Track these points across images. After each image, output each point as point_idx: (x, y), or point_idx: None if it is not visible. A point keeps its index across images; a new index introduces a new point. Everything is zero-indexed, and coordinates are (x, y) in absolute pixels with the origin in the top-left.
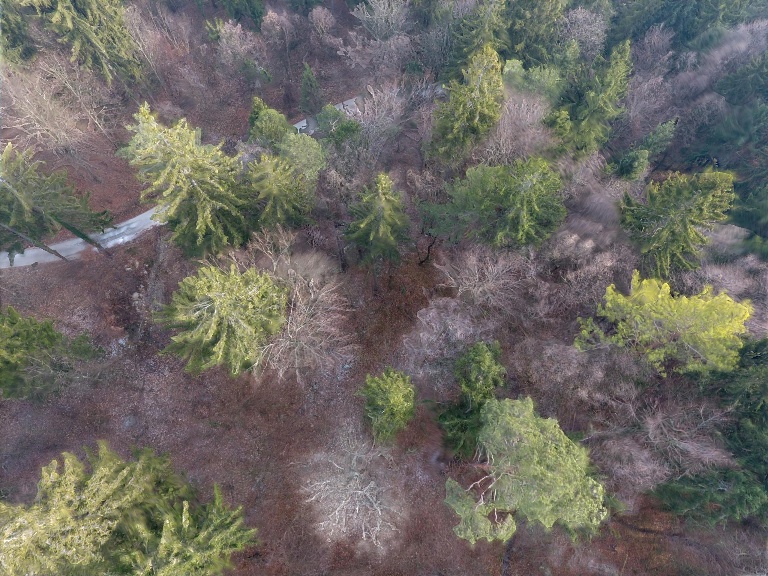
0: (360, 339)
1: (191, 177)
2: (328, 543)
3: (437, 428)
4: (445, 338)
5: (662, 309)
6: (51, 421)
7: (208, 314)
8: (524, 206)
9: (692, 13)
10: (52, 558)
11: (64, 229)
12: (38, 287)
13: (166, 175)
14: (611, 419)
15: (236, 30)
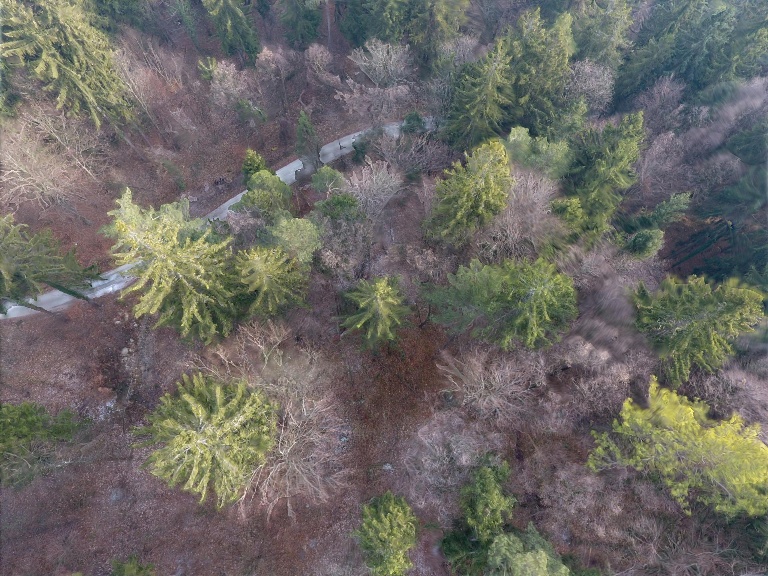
0: (358, 409)
1: (176, 270)
2: None
3: None
4: (449, 463)
5: (686, 438)
6: (34, 494)
7: (189, 454)
8: (534, 312)
9: (703, 62)
10: None
11: (49, 287)
12: (24, 342)
13: (147, 278)
14: (630, 556)
15: (229, 71)
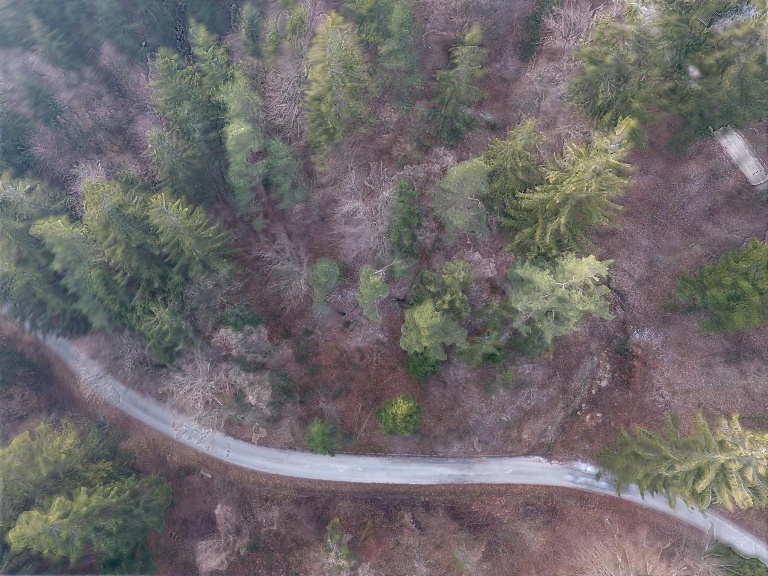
0: None
1: None
2: None
3: None
4: None
5: None
6: None
7: None
8: None
9: None
10: None
11: None
12: None
13: None
14: None
15: None
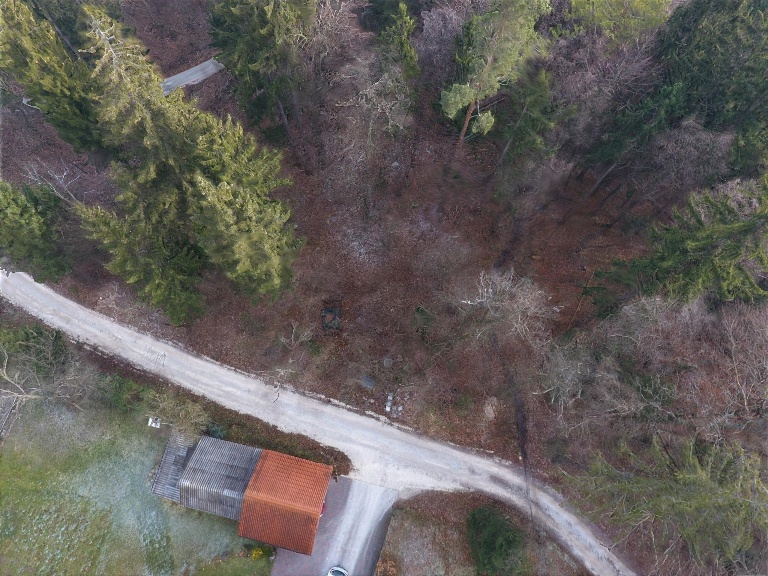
0: None
1: None
2: (344, 276)
3: (437, 189)
4: (443, 25)
5: None
6: None
7: None
8: None
9: None
10: (151, 110)
11: None
12: None
13: None
14: None
15: None
